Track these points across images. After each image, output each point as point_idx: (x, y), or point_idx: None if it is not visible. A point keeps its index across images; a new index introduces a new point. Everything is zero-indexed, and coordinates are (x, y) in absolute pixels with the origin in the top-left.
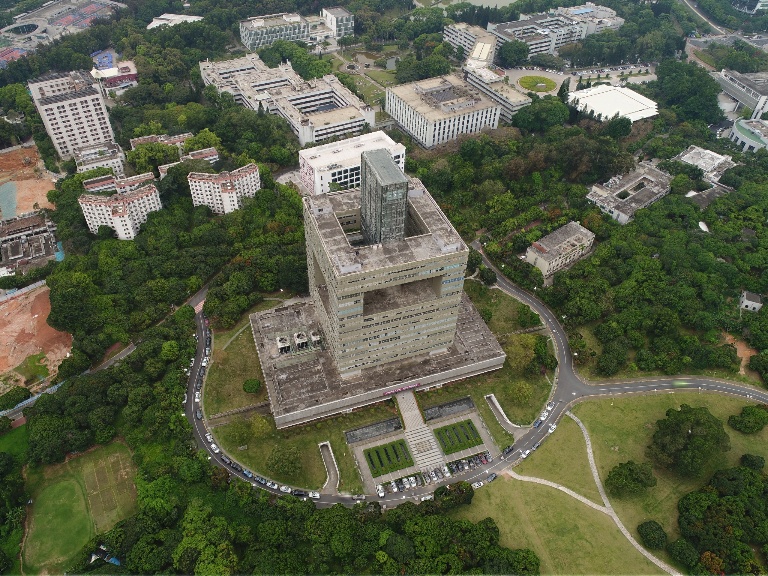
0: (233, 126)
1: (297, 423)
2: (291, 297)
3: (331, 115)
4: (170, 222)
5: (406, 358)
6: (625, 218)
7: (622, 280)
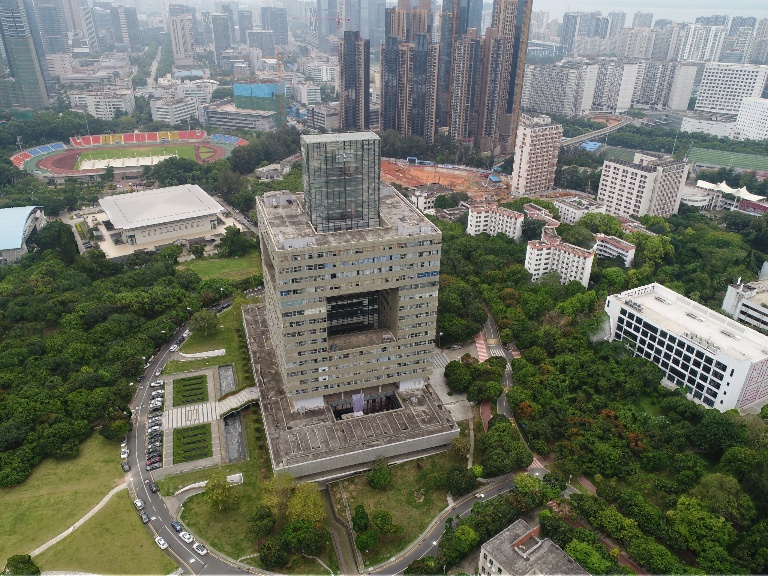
0: (701, 256)
1: None
2: None
3: None
4: None
5: None
6: None
7: None
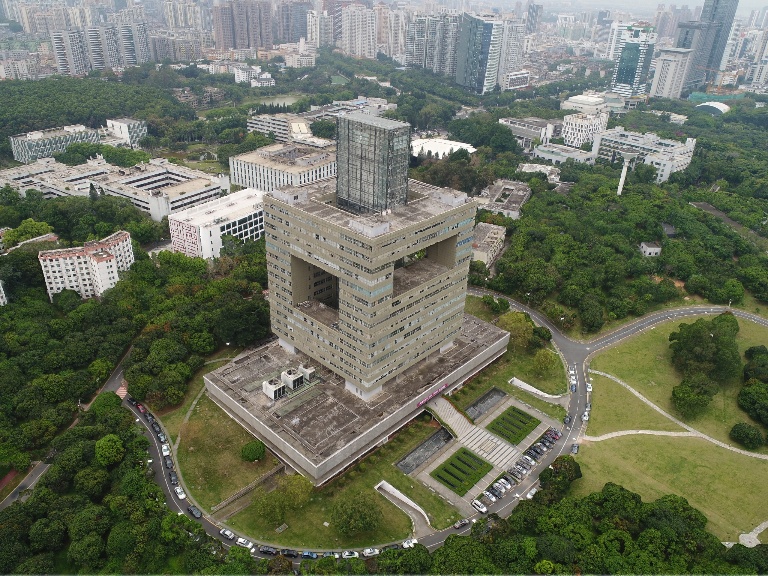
0: (62, 214)
1: (337, 472)
2: (238, 353)
3: (181, 187)
4: (28, 314)
5: (419, 363)
6: (515, 215)
7: (550, 257)
